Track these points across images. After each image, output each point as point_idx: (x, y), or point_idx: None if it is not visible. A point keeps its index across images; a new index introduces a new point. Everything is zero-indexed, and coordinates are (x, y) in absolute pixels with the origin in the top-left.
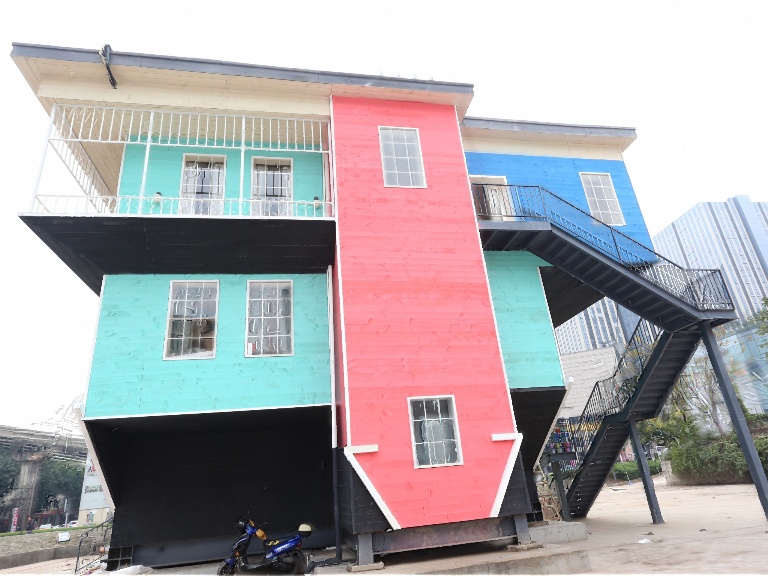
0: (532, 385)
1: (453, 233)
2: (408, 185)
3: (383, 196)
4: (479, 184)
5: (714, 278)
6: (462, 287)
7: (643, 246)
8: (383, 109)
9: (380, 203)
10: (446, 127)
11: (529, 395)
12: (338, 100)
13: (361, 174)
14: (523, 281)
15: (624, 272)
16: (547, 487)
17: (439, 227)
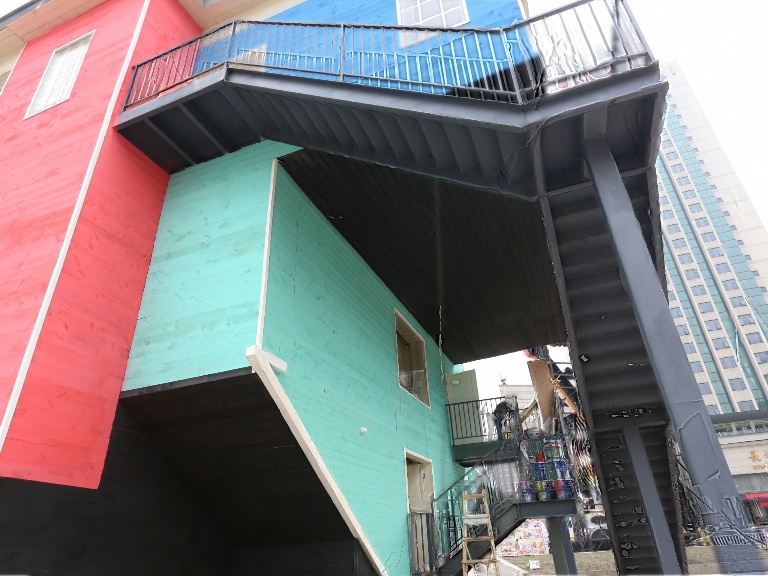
0: (195, 373)
1: (69, 145)
2: (49, 105)
3: (16, 132)
4: (147, 62)
5: (593, 14)
6: (41, 222)
7: (403, 27)
8: (70, 28)
9: (8, 142)
10: (131, 9)
11: (196, 393)
12: (30, 44)
13: (8, 116)
14: (242, 190)
15: (344, 96)
16: (495, 570)
17: (57, 144)
